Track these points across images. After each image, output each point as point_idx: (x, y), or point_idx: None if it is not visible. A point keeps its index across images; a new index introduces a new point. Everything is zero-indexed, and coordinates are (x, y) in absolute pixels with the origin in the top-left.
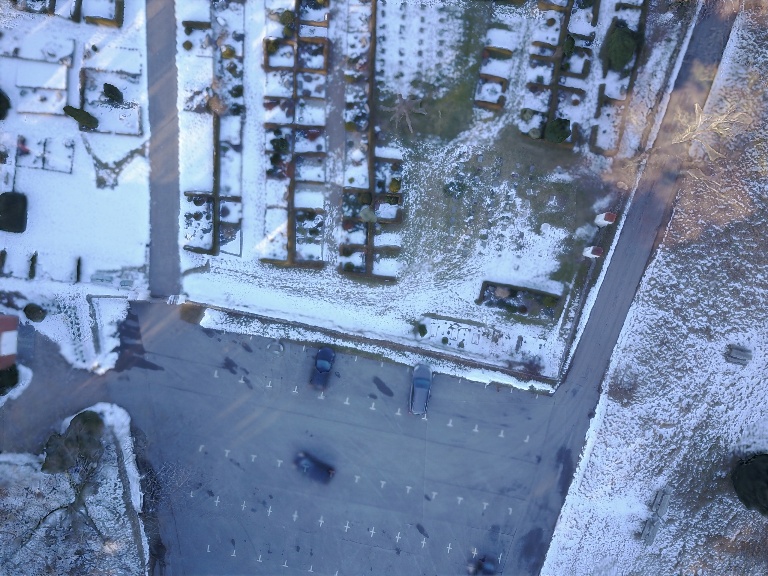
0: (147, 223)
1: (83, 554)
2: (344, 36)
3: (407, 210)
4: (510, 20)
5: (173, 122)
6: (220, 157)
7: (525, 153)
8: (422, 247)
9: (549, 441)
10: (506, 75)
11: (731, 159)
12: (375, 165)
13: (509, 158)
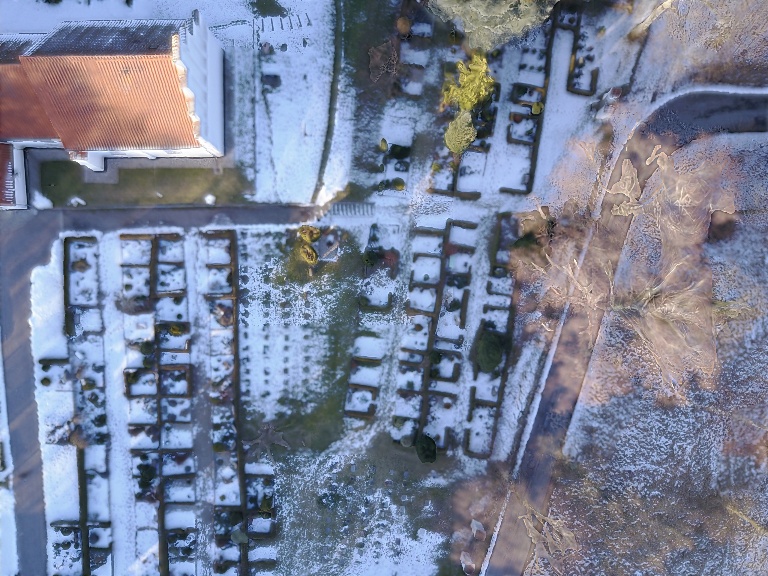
0: (14, 554)
1: None
2: (207, 360)
3: (281, 523)
4: (378, 327)
5: (36, 455)
6: (86, 485)
7: (398, 459)
8: (298, 559)
9: None
10: (376, 382)
11: (604, 458)
12: (246, 482)
13: (382, 465)
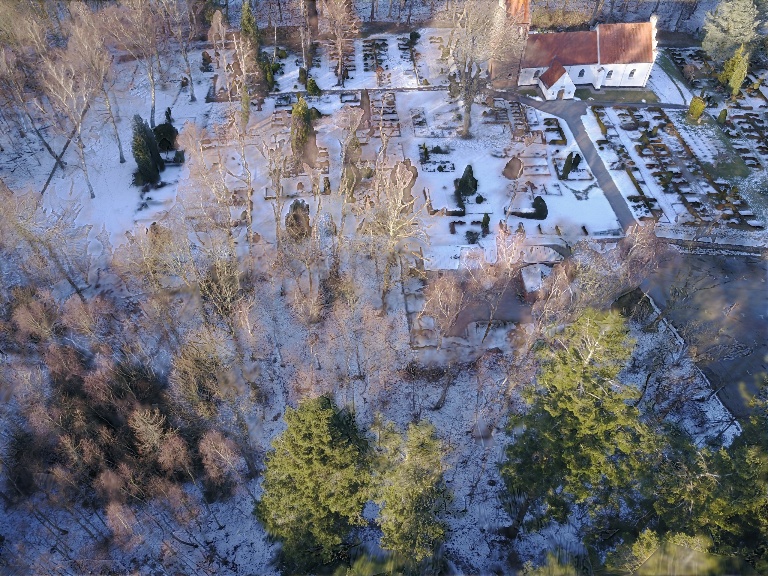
0: (612, 211)
1: (661, 382)
2: (670, 145)
3: (746, 202)
4: (739, 142)
5: (607, 174)
6: None
7: None
8: (766, 215)
9: None
10: None
11: None
12: None
13: None
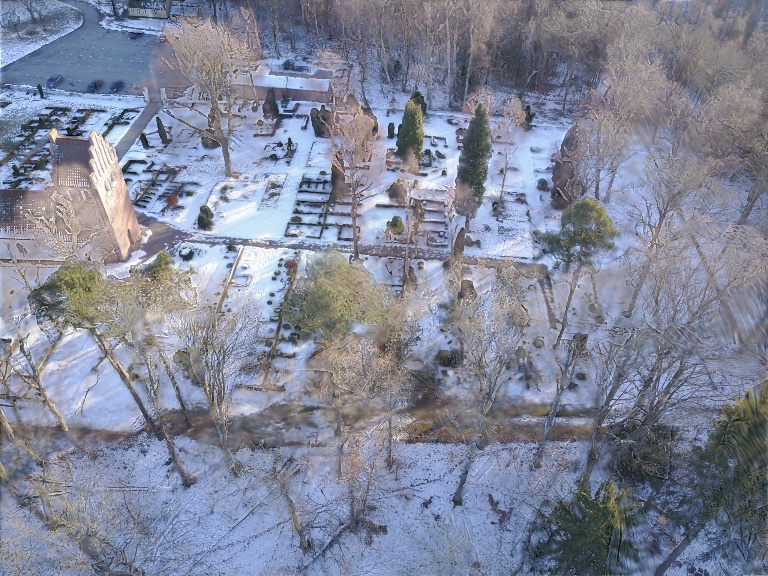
0: None
1: None
2: None
3: None
4: None
5: None
6: None
7: None
8: None
9: (8, 73)
10: None
11: None
12: None
13: None
